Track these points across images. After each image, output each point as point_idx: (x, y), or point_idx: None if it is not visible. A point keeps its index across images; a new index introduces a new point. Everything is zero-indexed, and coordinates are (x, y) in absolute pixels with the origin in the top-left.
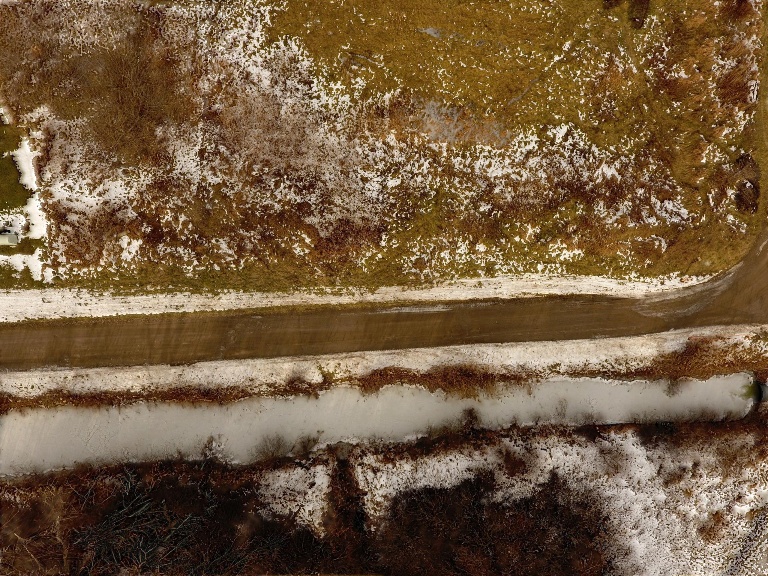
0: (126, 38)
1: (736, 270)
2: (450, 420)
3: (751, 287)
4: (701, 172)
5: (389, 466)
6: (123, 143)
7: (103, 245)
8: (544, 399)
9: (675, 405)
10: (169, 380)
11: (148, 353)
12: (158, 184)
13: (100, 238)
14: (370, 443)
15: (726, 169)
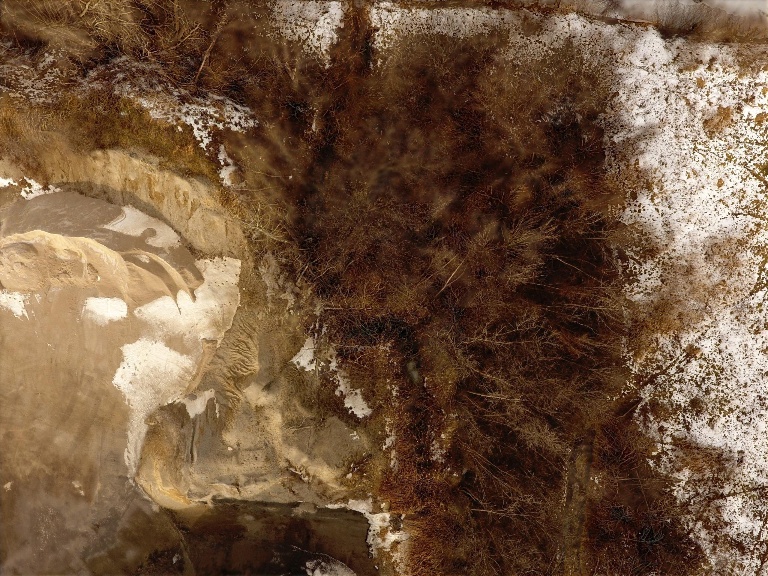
0: None
1: None
2: None
3: None
4: None
5: (405, 10)
6: None
7: None
8: None
9: None
10: None
11: None
12: None
13: None
14: None
15: None
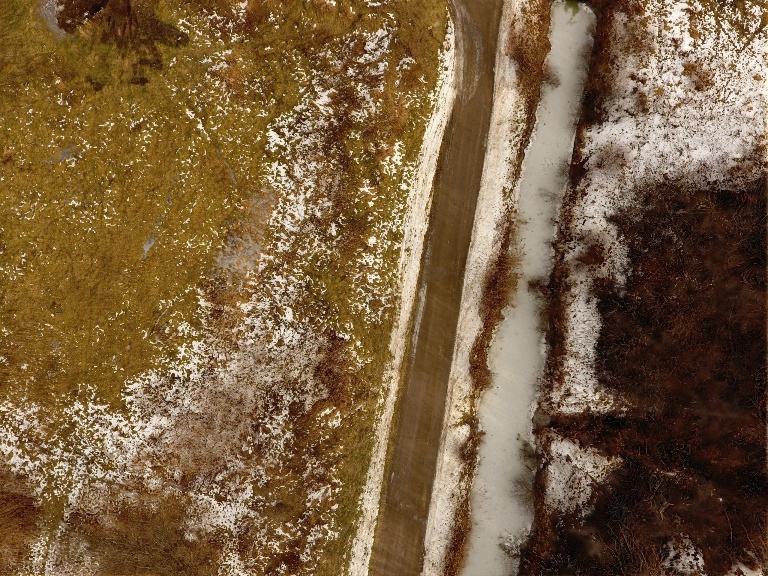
0: (89, 550)
1: None
2: (535, 309)
3: None
4: (345, 8)
5: (567, 379)
6: (193, 574)
7: None
8: (534, 210)
9: (568, 81)
10: None
11: None
12: (240, 548)
13: None
14: (540, 391)
15: None
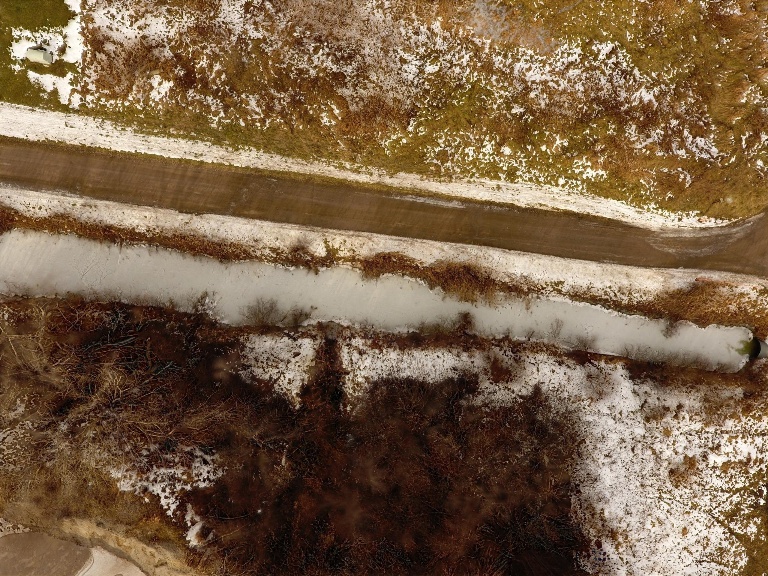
0: None
1: (756, 220)
2: (444, 317)
3: (767, 239)
4: (739, 111)
5: (376, 351)
6: None
7: (134, 80)
8: (541, 317)
9: (670, 346)
10: (175, 226)
11: (159, 196)
12: (199, 28)
13: (133, 73)
14: (361, 328)
15: (765, 112)
